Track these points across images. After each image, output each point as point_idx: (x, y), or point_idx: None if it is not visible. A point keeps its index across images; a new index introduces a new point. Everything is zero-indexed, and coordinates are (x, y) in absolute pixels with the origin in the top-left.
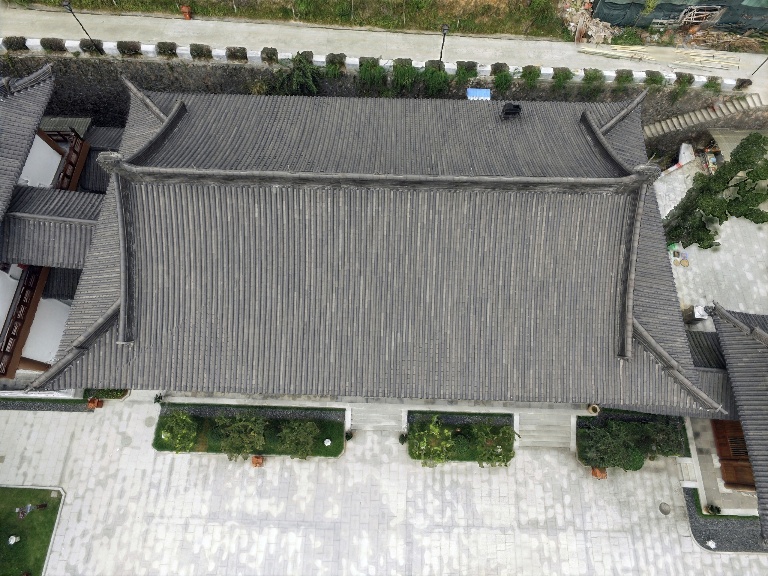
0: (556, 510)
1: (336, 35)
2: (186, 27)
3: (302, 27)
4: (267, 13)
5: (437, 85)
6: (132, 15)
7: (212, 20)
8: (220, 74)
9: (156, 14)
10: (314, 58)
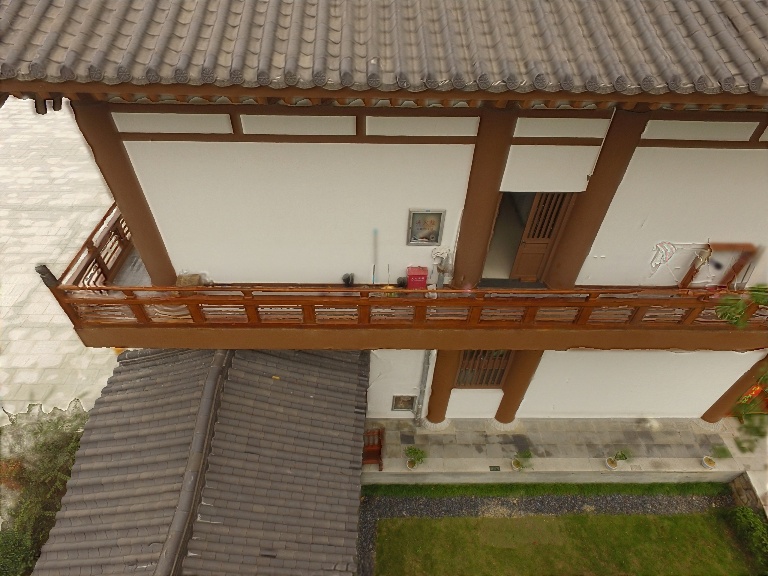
0: None
1: None
2: None
3: None
4: None
5: None
6: None
7: None
8: None
9: None
10: None
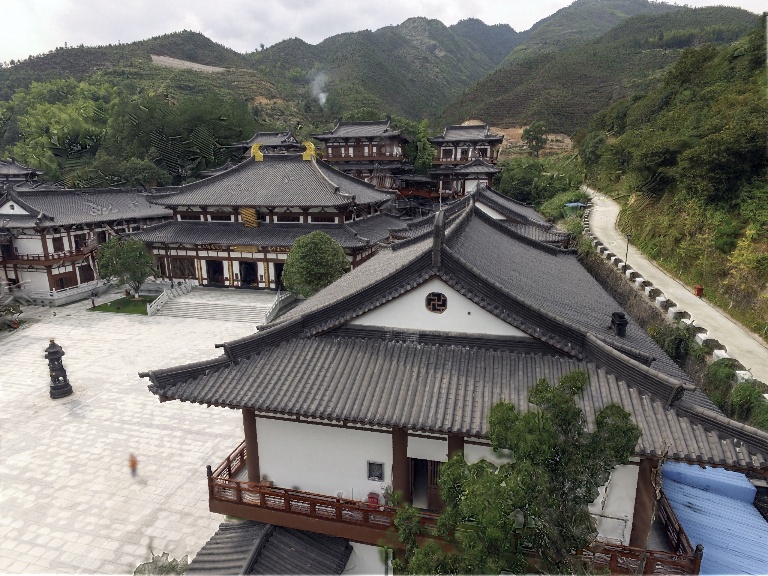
0: (142, 547)
1: (767, 357)
2: (685, 295)
3: (755, 340)
4: (748, 321)
5: (759, 426)
6: (678, 282)
7: (708, 304)
8: (649, 313)
9: (689, 287)
10: (701, 334)
